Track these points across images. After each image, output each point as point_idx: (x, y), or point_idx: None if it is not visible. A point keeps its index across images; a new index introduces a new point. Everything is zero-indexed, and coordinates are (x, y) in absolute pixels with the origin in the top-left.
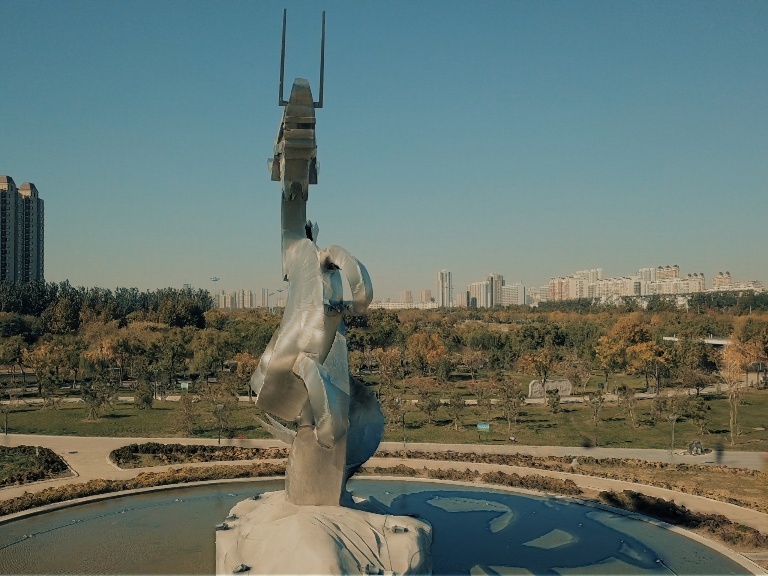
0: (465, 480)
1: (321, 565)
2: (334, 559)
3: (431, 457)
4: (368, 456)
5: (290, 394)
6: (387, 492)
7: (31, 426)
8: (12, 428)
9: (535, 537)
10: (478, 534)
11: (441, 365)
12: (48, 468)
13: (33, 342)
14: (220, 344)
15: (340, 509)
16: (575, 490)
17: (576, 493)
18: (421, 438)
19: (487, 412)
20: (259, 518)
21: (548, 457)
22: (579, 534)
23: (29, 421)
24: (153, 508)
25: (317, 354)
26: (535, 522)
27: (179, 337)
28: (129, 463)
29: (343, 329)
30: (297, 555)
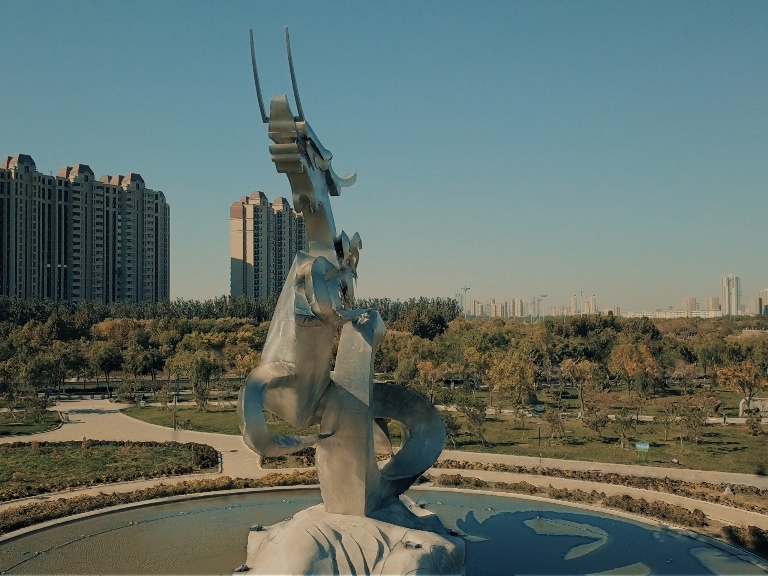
0: (584, 502)
1: (285, 572)
2: (302, 567)
3: (567, 475)
4: (424, 469)
5: (284, 402)
6: (489, 508)
7: (219, 425)
8: (202, 426)
9: (607, 569)
10: (552, 560)
11: (637, 378)
12: (198, 464)
13: (258, 349)
14: (425, 353)
15: (362, 520)
16: (697, 522)
17: (697, 525)
18: (575, 455)
19: (664, 431)
20: (290, 522)
21: (700, 483)
22: (660, 570)
23: (221, 421)
24: (258, 507)
25: (293, 363)
26: (624, 553)
27: (390, 346)
28: (272, 463)
29: (372, 339)
30: (274, 560)
